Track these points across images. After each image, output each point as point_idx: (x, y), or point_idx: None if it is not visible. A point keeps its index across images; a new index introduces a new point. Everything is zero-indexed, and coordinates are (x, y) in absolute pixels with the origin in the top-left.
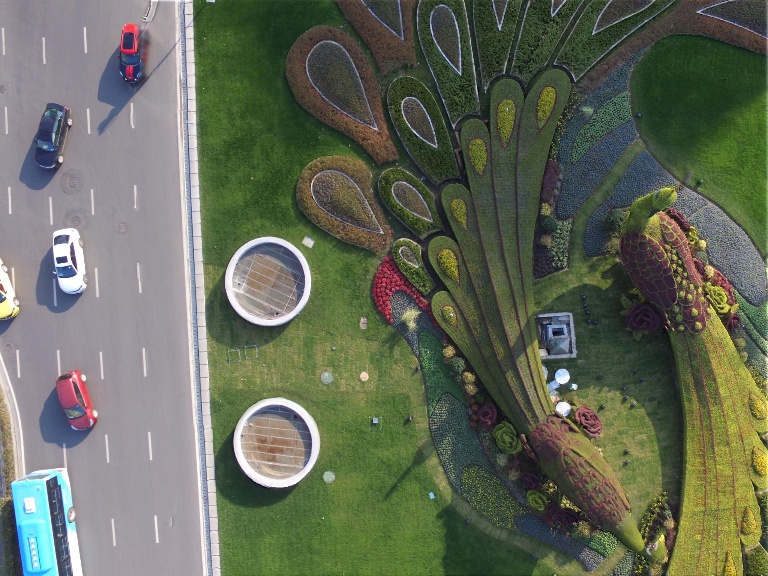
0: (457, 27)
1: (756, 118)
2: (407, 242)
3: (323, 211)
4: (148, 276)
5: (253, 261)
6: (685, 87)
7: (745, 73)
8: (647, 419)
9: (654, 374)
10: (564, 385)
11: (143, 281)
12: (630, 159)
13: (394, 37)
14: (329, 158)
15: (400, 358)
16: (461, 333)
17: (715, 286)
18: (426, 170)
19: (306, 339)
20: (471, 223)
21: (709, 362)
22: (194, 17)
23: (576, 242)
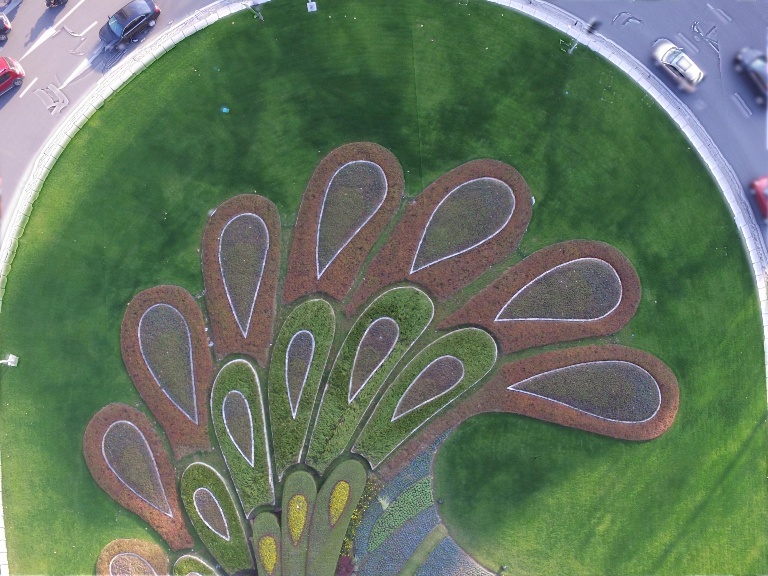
0: (250, 415)
1: (568, 496)
2: None
3: None
4: None
5: None
6: (491, 468)
7: (558, 449)
8: None
9: None
10: None
11: None
12: (430, 546)
13: (188, 421)
14: (126, 542)
15: None
16: None
17: None
18: (219, 562)
19: None
20: None
21: None
22: None
23: None
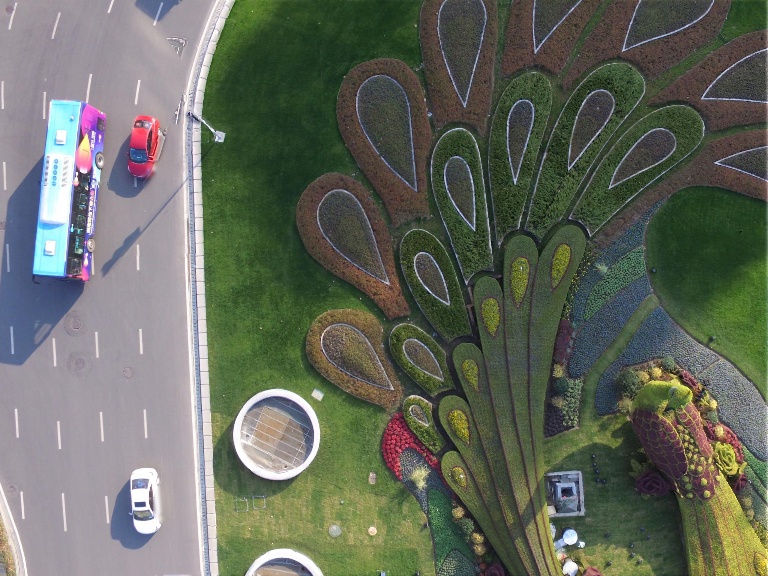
0: (472, 180)
1: None
2: (418, 400)
3: (333, 365)
4: (155, 423)
5: (262, 413)
6: (700, 241)
7: (761, 225)
8: (653, 575)
9: (661, 531)
10: None
11: (150, 428)
12: (643, 315)
13: (407, 188)
14: (340, 312)
15: (409, 514)
16: (470, 495)
17: (724, 444)
18: (438, 327)
19: (314, 492)
20: (482, 385)
21: (716, 527)
22: (202, 157)
23: (587, 401)
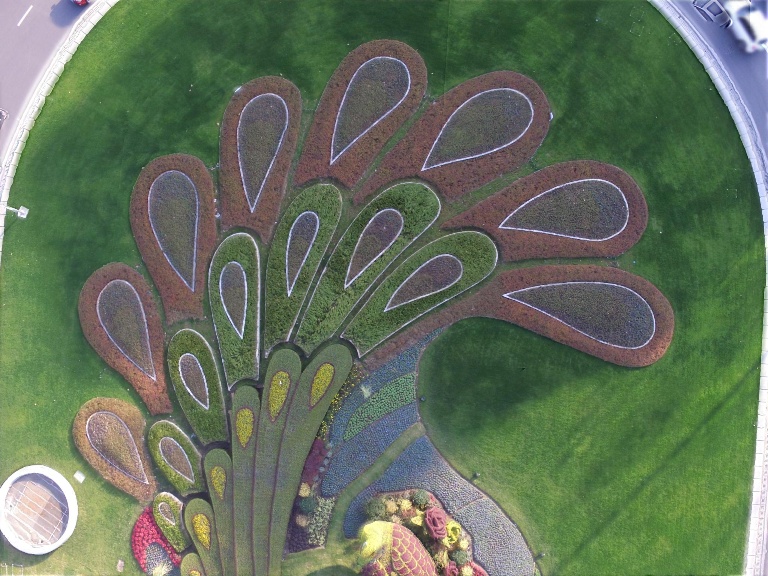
0: (246, 287)
1: (550, 413)
2: (167, 498)
3: (95, 451)
4: None
5: (26, 486)
6: (477, 374)
7: (547, 364)
8: None
9: None
10: None
11: None
12: (406, 443)
13: (184, 287)
14: (106, 400)
15: None
16: None
17: None
18: (195, 430)
19: (67, 570)
20: (227, 494)
21: None
22: (5, 229)
23: (336, 522)
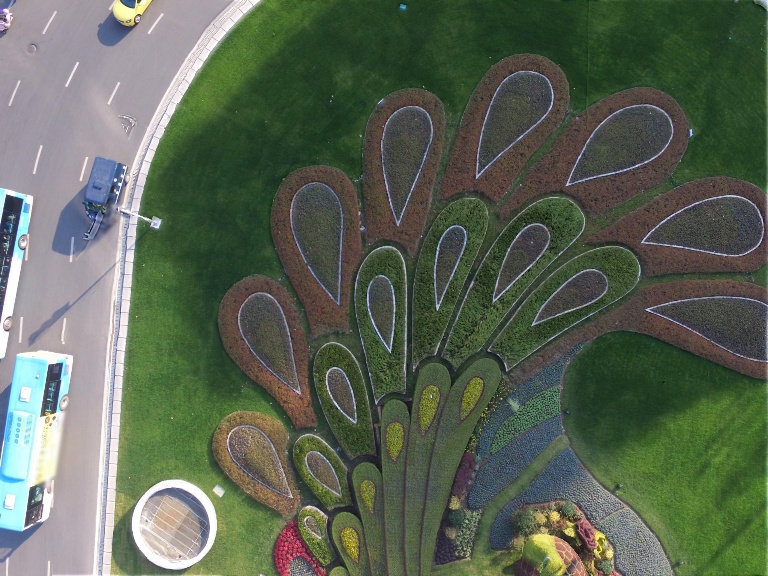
0: (394, 301)
1: (689, 425)
2: (313, 512)
3: (236, 465)
4: (62, 494)
5: (163, 501)
6: (620, 387)
7: (686, 377)
8: None
9: None
10: None
11: (56, 498)
12: (551, 455)
13: (330, 300)
14: (249, 414)
15: None
16: None
17: None
18: (342, 443)
19: None
20: (378, 507)
21: None
22: (136, 240)
23: (483, 534)
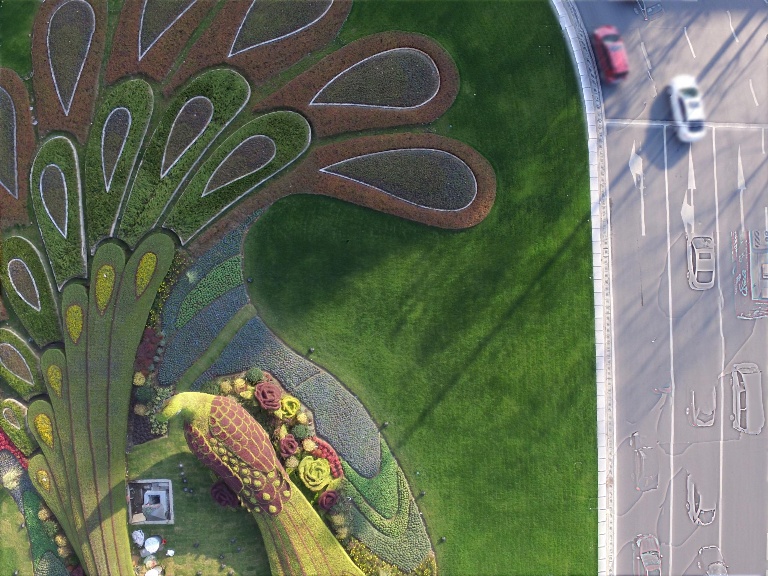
0: (65, 188)
1: (379, 282)
2: (10, 404)
3: None
4: None
5: None
6: (302, 250)
7: (371, 234)
8: None
9: (253, 544)
10: (161, 551)
11: None
12: (238, 325)
13: (8, 196)
14: None
15: (8, 514)
16: (53, 498)
17: (318, 459)
18: (30, 333)
19: None
20: (64, 391)
21: (290, 543)
22: None
23: None
